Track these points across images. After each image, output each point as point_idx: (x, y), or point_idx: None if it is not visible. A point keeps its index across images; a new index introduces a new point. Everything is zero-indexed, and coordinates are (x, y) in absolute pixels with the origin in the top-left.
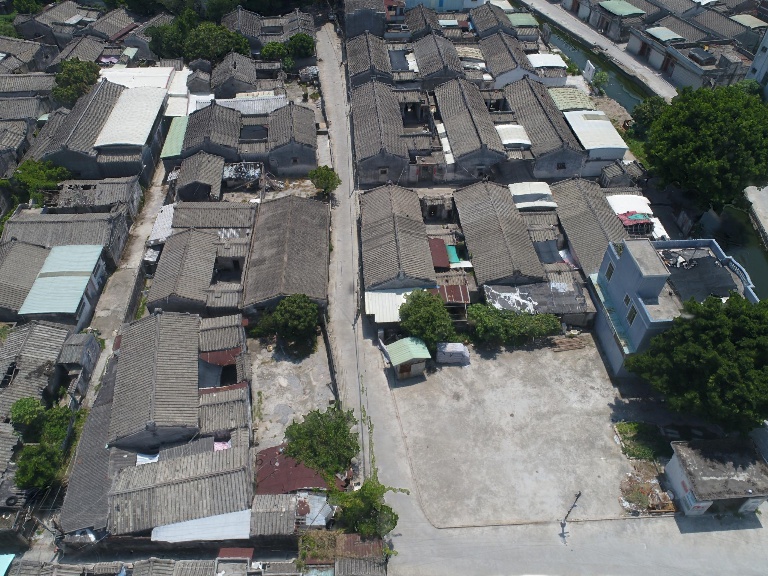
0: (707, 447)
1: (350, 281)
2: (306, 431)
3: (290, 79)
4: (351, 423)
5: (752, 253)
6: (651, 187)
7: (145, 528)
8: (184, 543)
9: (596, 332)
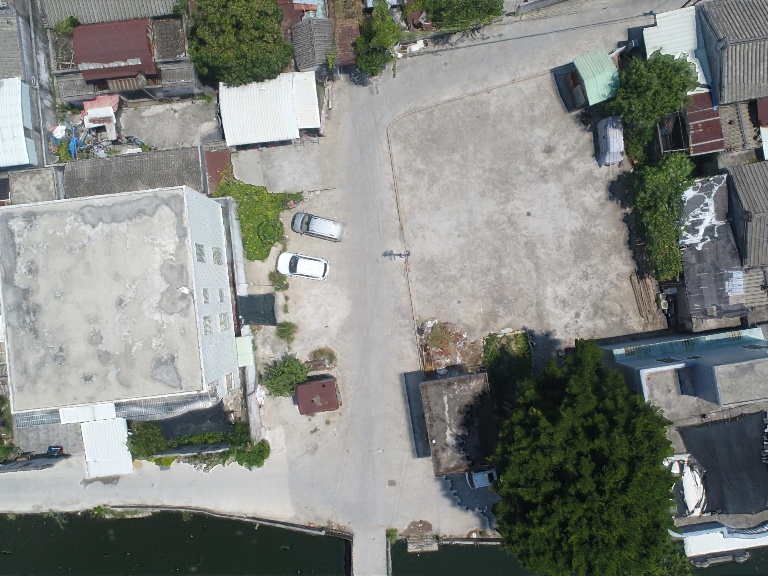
0: (484, 412)
1: None
2: None
3: None
4: (484, 15)
5: None
6: None
7: None
8: None
9: (669, 335)
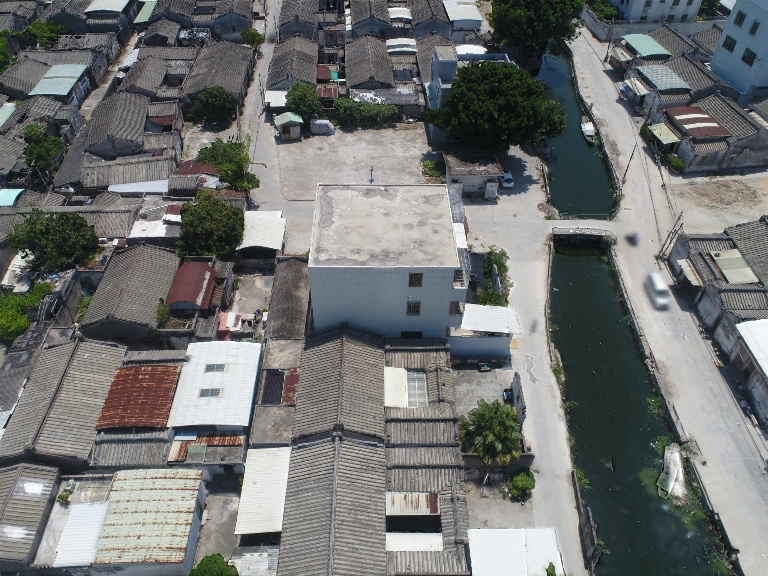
0: (466, 157)
1: None
2: (211, 148)
3: None
4: (241, 147)
5: (566, 92)
6: (502, 52)
7: (104, 185)
8: (128, 196)
9: None
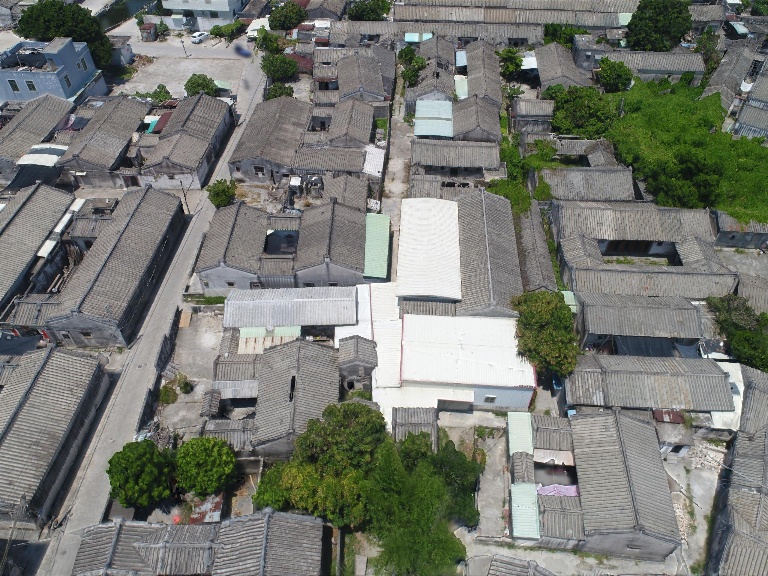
0: None
1: (235, 143)
2: (286, 60)
3: None
4: None
5: None
6: None
7: None
8: None
9: None
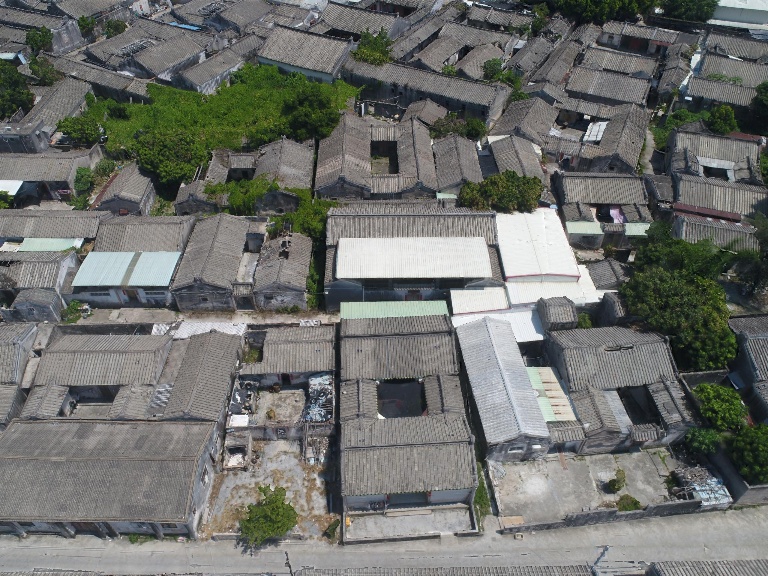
0: None
1: None
2: None
3: (687, 455)
4: None
5: None
6: None
7: None
8: None
9: None
